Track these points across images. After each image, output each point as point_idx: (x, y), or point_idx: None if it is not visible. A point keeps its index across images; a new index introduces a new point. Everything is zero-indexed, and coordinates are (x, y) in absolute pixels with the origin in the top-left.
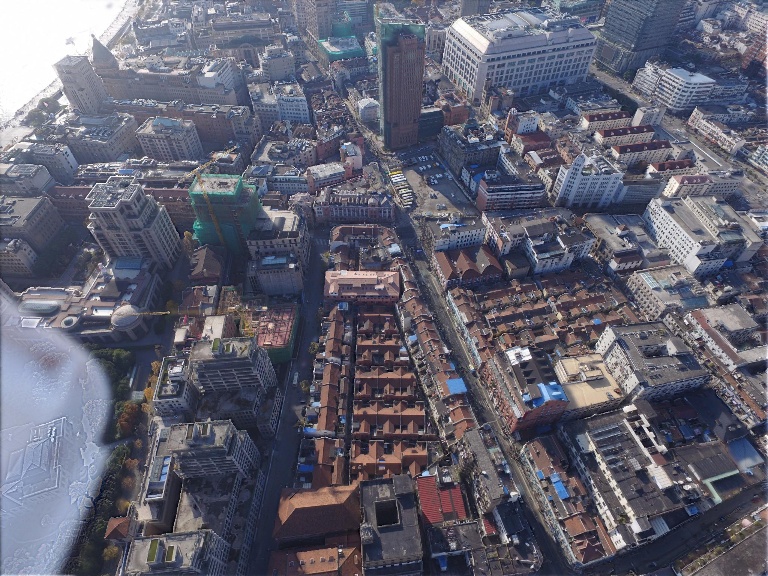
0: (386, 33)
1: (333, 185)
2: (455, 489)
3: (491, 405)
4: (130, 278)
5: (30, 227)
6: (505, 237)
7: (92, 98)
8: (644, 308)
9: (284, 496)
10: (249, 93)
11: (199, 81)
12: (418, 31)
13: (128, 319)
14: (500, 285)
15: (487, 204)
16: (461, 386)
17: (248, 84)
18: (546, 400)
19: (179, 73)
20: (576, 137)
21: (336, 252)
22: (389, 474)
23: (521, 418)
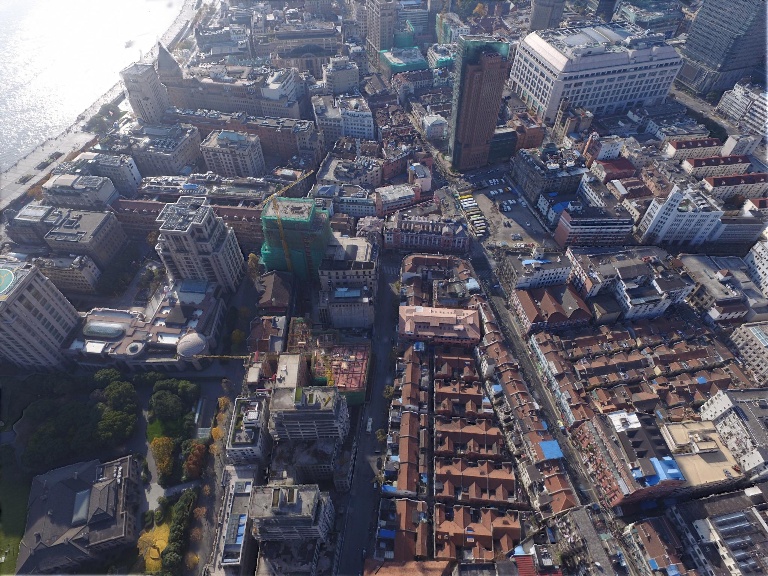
0: (468, 51)
1: (402, 209)
2: (557, 574)
3: (585, 470)
4: (195, 303)
5: (95, 243)
6: (595, 278)
7: (156, 107)
8: (752, 366)
9: (368, 569)
10: (313, 106)
11: (263, 92)
12: (502, 49)
13: (195, 349)
14: (589, 331)
15: (569, 237)
16: (556, 450)
17: (311, 96)
18: (662, 479)
19: (243, 84)
20: (663, 166)
21: (408, 284)
22: (479, 548)
23: (629, 494)
